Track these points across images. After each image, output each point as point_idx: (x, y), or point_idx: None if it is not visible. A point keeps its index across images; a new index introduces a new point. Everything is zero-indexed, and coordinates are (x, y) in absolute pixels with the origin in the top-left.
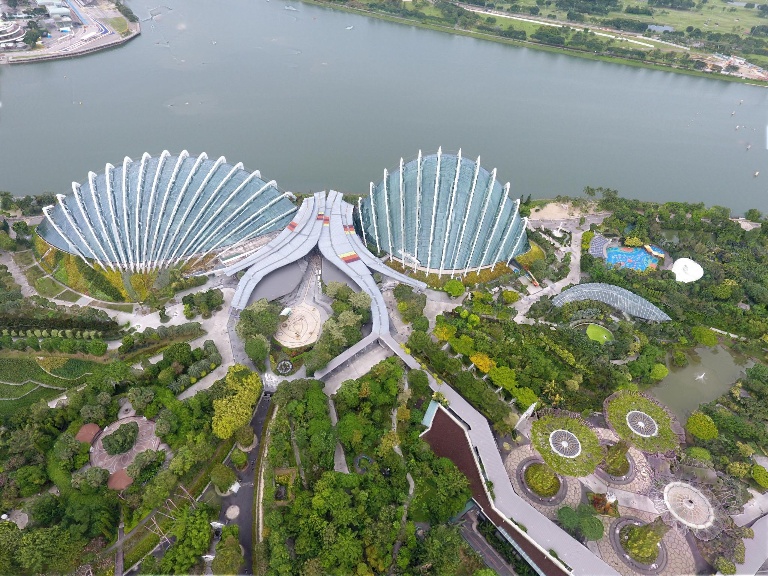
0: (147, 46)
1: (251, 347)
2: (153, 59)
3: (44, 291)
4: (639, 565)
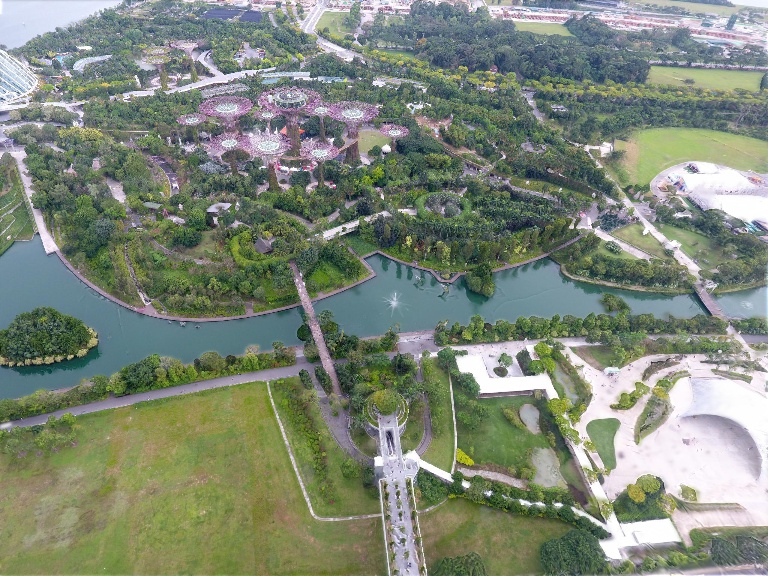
0: None
1: (49, 126)
2: None
3: None
4: None
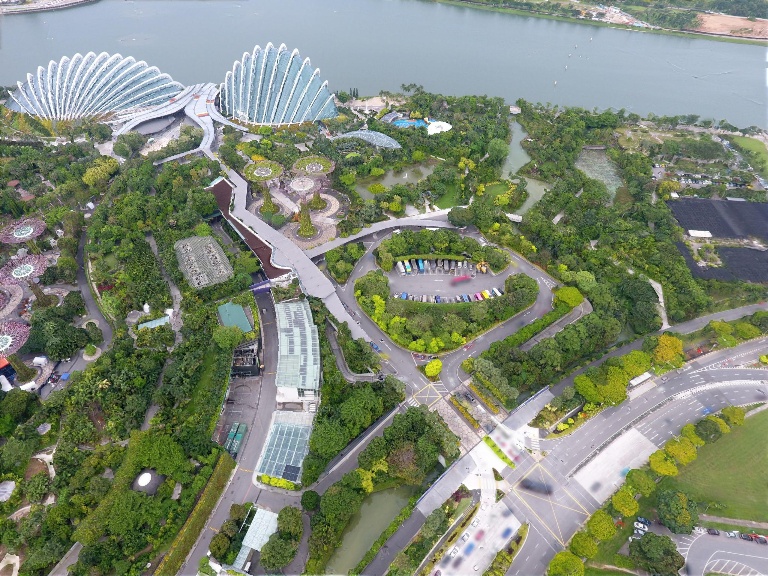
0: (116, 3)
1: (116, 147)
2: (118, 11)
3: (3, 132)
4: (301, 238)
